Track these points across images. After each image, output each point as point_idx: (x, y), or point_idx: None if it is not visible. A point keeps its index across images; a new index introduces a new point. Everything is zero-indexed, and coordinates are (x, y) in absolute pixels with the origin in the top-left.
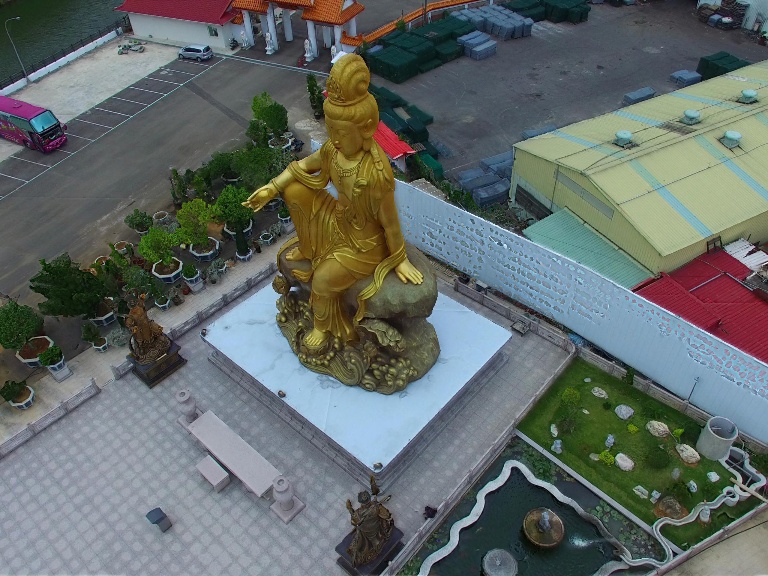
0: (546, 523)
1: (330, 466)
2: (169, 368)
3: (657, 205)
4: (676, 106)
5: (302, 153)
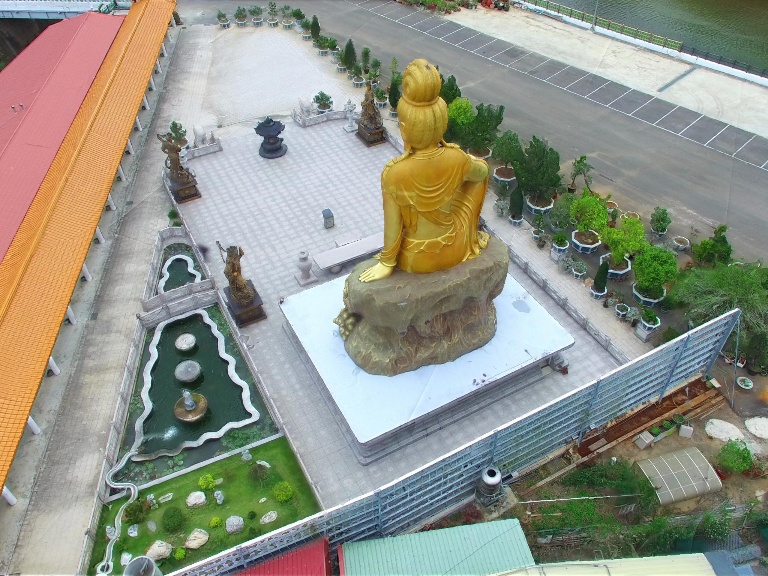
0: None
1: None
2: None
3: None
4: None
5: None
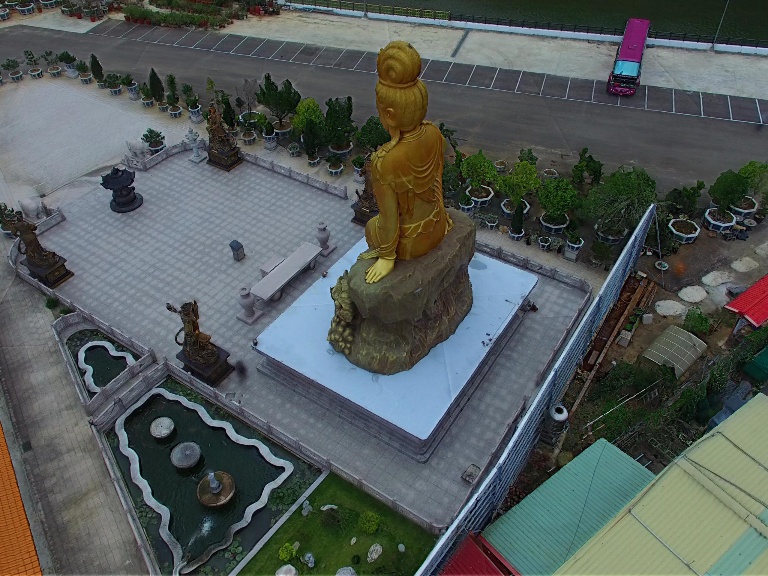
0: None
1: None
2: None
3: None
4: None
5: (723, 242)
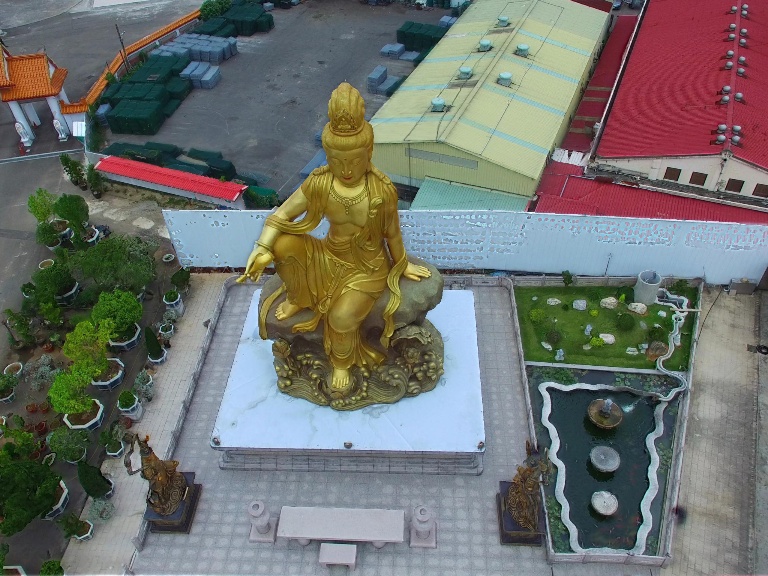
0: (610, 408)
1: (423, 480)
2: (192, 502)
3: (503, 145)
4: (440, 69)
5: None
